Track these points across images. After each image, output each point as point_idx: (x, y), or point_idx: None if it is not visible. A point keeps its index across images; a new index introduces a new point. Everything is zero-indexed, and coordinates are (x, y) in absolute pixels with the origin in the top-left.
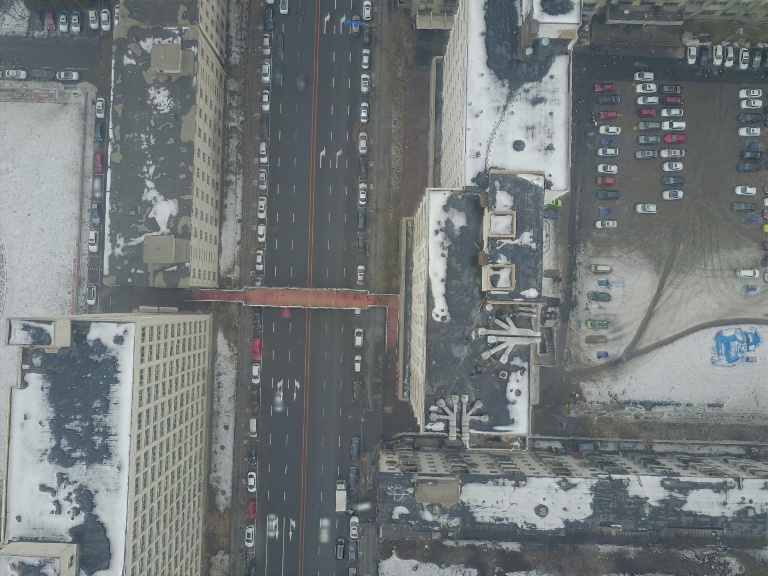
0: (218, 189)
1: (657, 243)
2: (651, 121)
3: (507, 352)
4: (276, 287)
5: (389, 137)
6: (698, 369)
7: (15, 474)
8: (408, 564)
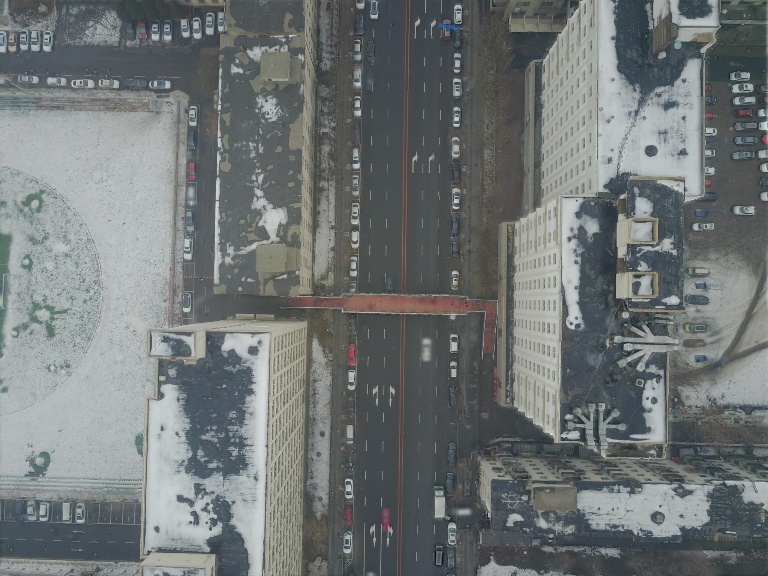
0: (312, 196)
1: (755, 245)
2: (748, 122)
3: (644, 360)
4: (374, 293)
5: (482, 141)
6: None
7: (153, 485)
8: (507, 570)
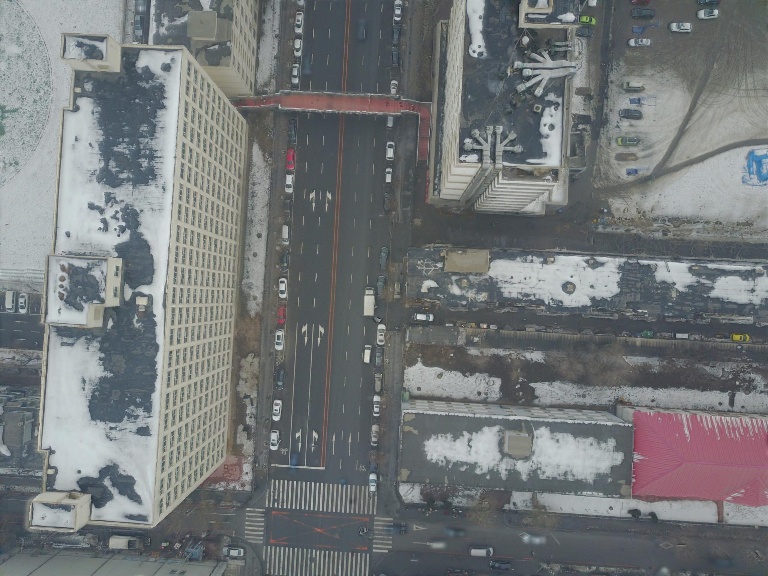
0: (257, 3)
1: (690, 62)
2: None
3: (542, 85)
4: None
5: None
6: (728, 188)
7: (65, 193)
8: (433, 371)
